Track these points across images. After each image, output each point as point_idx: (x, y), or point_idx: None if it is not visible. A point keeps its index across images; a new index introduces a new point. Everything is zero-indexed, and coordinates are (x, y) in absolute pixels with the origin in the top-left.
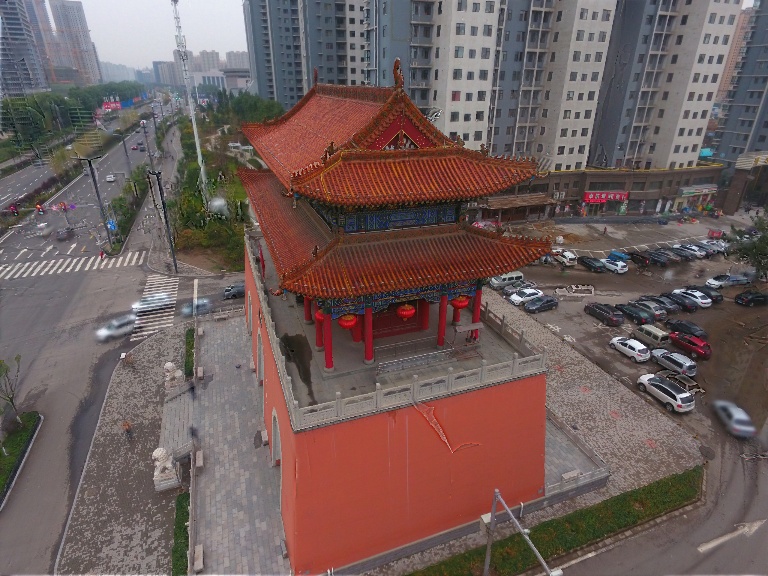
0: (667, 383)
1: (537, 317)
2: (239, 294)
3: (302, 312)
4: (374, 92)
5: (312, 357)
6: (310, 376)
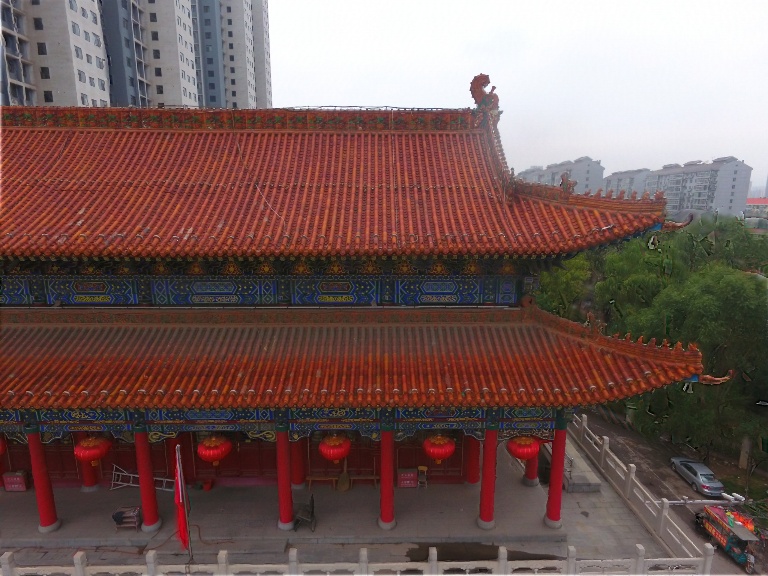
0: None
1: None
2: None
3: (338, 529)
4: (396, 116)
5: (495, 545)
6: (554, 556)
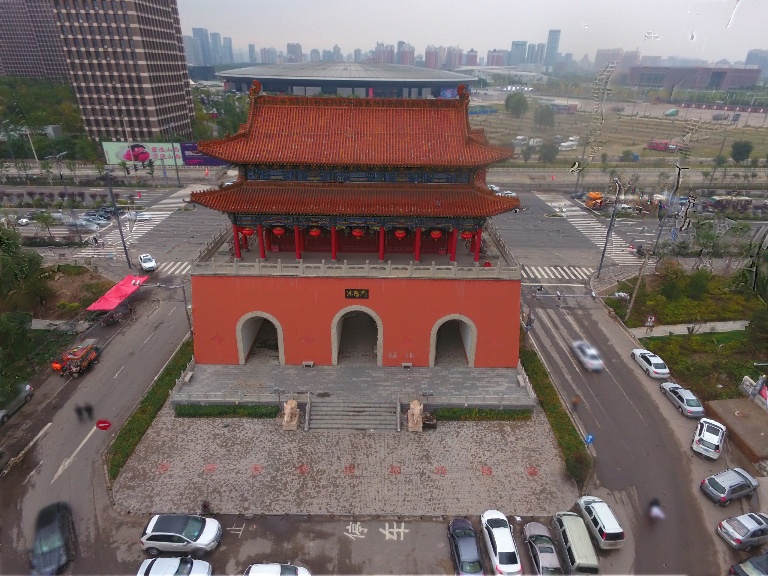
0: (180, 524)
1: (434, 528)
2: (546, 301)
3: None
4: None
5: None
6: None
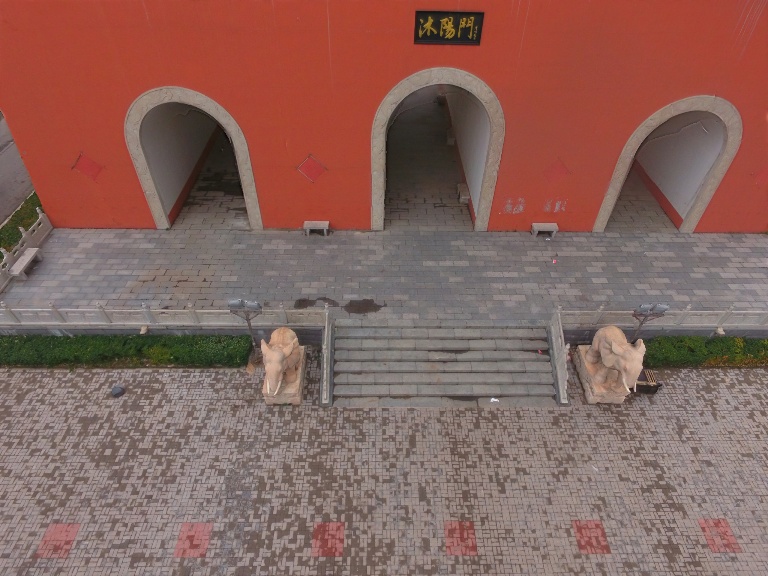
0: None
1: None
2: None
3: None
4: None
5: None
6: None
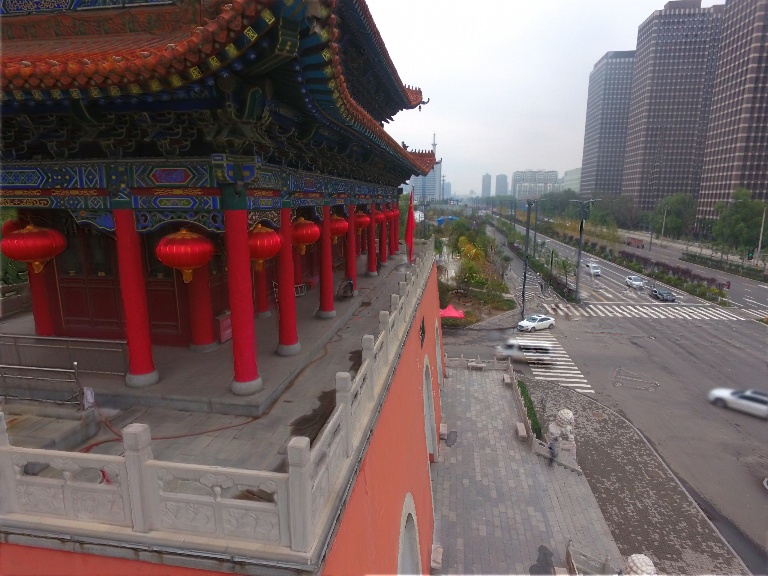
0: None
1: None
2: None
3: None
4: None
5: (400, 264)
6: None
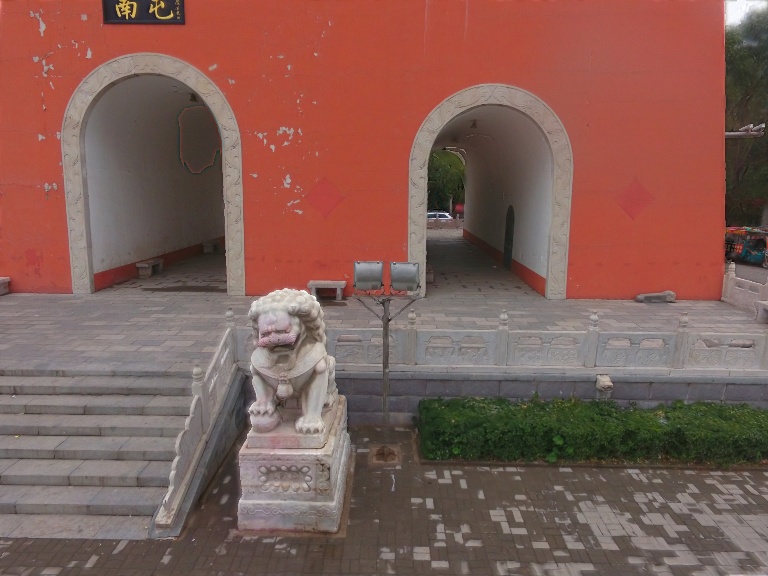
0: None
1: None
2: None
3: None
4: None
5: None
6: None
